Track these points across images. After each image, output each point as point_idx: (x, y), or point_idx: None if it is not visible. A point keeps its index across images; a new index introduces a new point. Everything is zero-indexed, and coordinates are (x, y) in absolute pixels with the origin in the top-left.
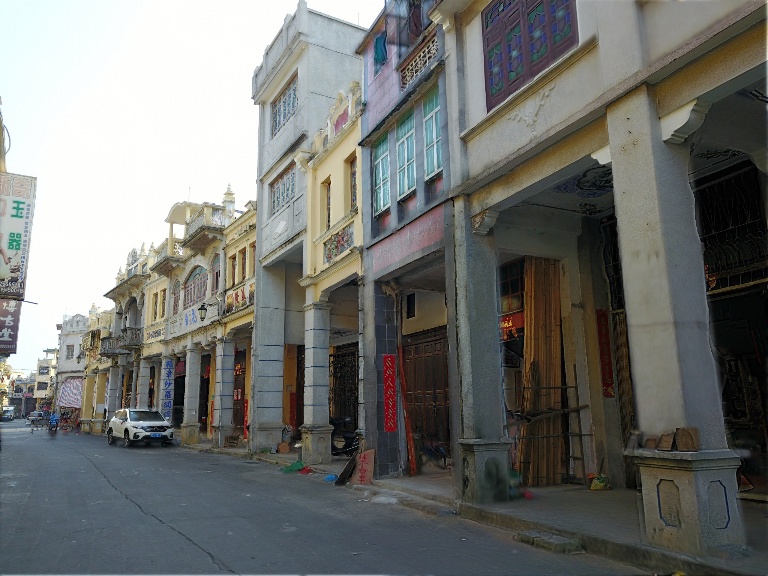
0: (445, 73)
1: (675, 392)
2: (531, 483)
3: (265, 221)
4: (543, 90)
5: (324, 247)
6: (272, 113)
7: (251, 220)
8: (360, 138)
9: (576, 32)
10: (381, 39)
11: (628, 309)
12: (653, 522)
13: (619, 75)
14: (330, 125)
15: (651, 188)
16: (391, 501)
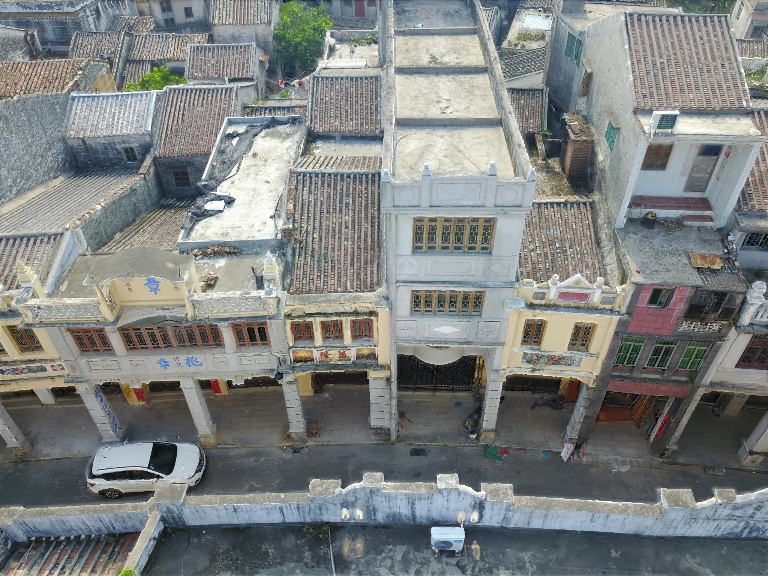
0: (722, 345)
1: None
2: (639, 421)
3: (406, 317)
4: None
5: (524, 354)
6: None
7: (357, 304)
8: (614, 328)
9: None
10: None
11: (767, 431)
12: (747, 462)
13: None
14: (555, 291)
15: None
16: (630, 468)
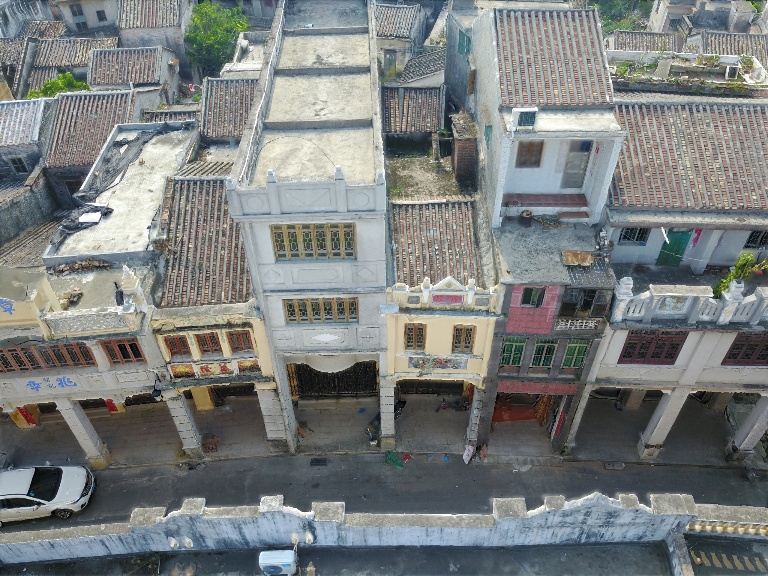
0: None
1: (664, 438)
2: None
3: (282, 327)
4: (652, 368)
5: None
6: (272, 233)
7: (229, 316)
8: (493, 329)
9: (675, 360)
10: (541, 295)
11: (658, 424)
12: None
13: (687, 382)
14: (428, 295)
15: (681, 406)
16: (531, 467)
